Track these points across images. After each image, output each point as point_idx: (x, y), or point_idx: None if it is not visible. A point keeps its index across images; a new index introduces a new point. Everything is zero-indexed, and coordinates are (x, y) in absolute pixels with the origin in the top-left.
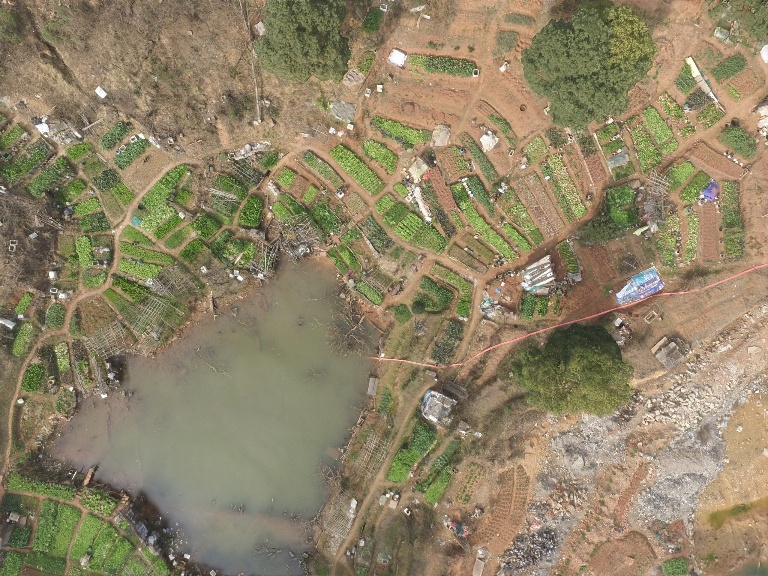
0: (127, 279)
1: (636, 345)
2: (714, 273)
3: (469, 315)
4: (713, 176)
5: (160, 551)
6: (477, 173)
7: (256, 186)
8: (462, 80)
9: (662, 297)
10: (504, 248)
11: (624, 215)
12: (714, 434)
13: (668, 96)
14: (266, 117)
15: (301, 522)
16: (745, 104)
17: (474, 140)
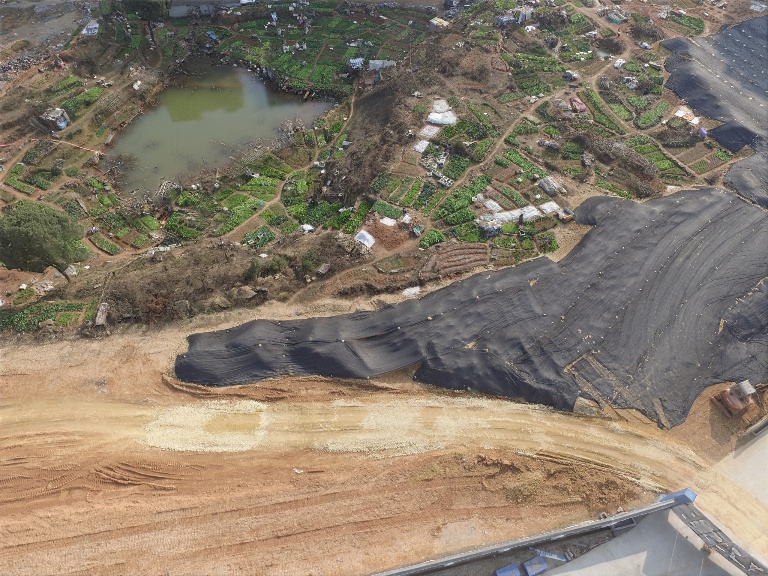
0: None
1: None
2: None
3: None
4: None
5: None
6: None
7: None
8: None
9: None
10: None
11: None
12: None
13: None
14: None
15: (177, 84)
16: None
17: None
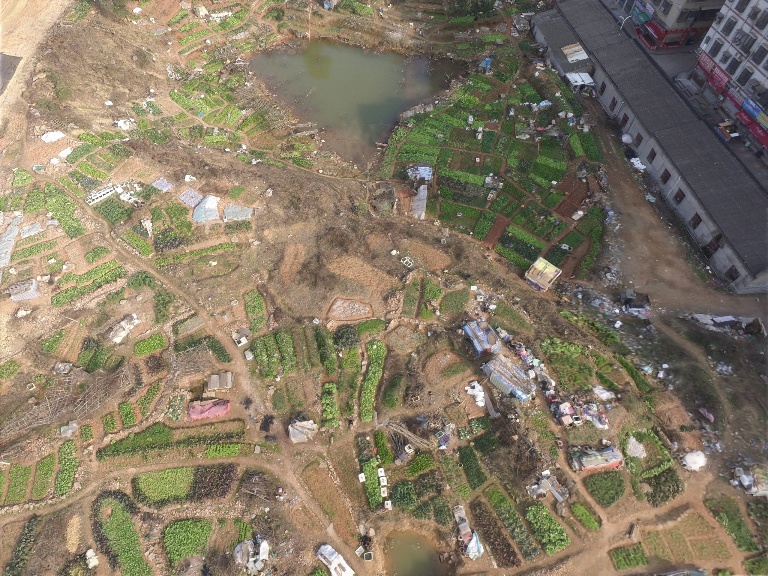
0: None
1: None
2: None
3: None
4: None
5: None
6: None
7: None
8: None
9: None
10: None
11: None
12: None
13: None
14: None
15: (409, 59)
16: None
17: None
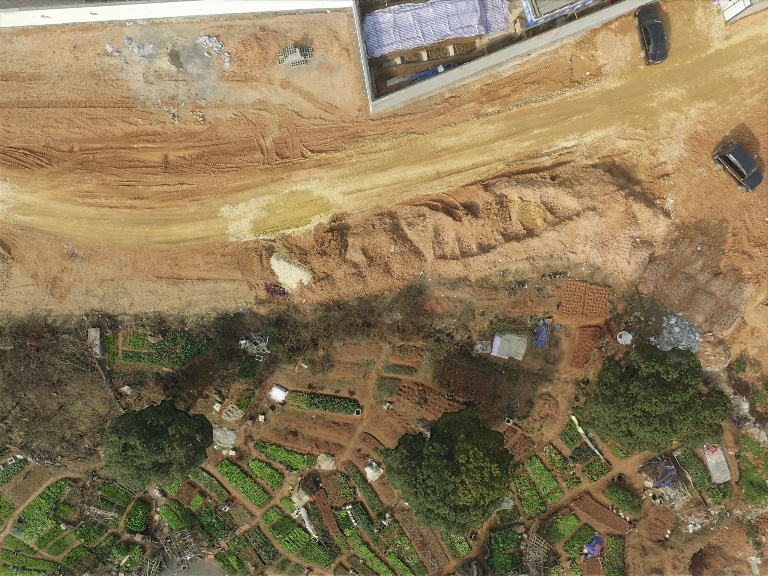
0: None
1: None
2: None
3: None
4: (598, 529)
5: None
6: (362, 500)
7: (142, 491)
8: (345, 416)
9: None
10: None
11: (508, 560)
12: None
13: (553, 448)
14: None
15: None
16: (631, 462)
17: (359, 469)
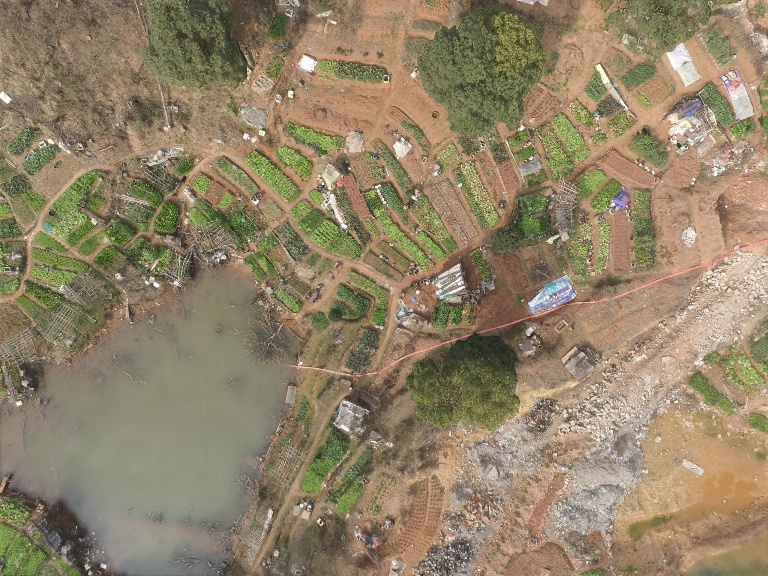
0: (41, 286)
1: (546, 355)
2: (625, 282)
3: (385, 323)
4: (625, 184)
5: (74, 561)
6: (391, 180)
7: (172, 192)
8: (373, 86)
9: (574, 306)
10: (418, 256)
11: (536, 223)
12: (631, 444)
13: (579, 103)
14: (176, 123)
15: (219, 532)
16: (656, 112)
17: (387, 147)
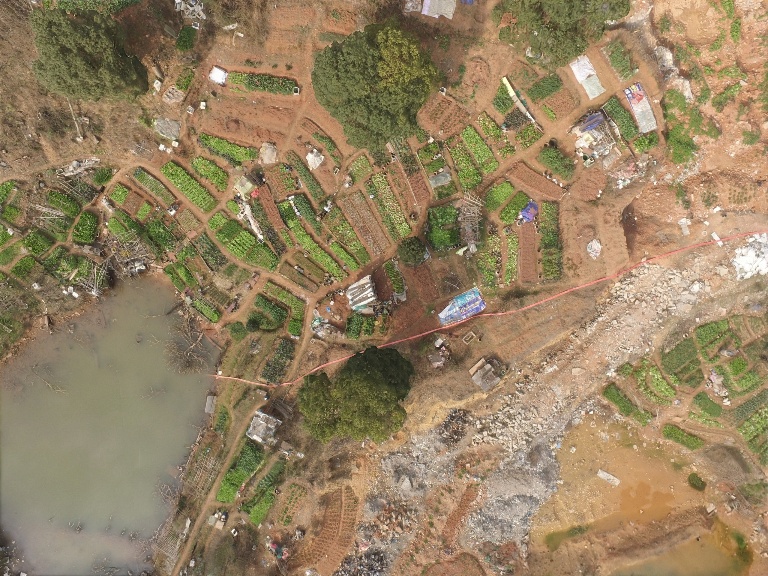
0: None
1: (453, 366)
2: (532, 294)
3: (301, 334)
4: (533, 196)
5: None
6: (305, 191)
7: (90, 202)
8: (284, 98)
9: (482, 318)
10: (332, 267)
11: (446, 235)
12: (546, 455)
13: (487, 116)
14: (88, 134)
15: (139, 541)
16: (562, 124)
17: (300, 158)
